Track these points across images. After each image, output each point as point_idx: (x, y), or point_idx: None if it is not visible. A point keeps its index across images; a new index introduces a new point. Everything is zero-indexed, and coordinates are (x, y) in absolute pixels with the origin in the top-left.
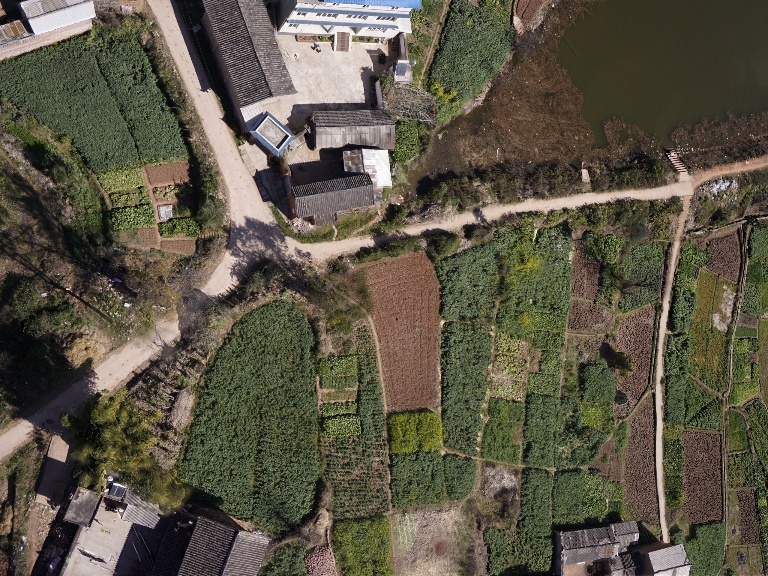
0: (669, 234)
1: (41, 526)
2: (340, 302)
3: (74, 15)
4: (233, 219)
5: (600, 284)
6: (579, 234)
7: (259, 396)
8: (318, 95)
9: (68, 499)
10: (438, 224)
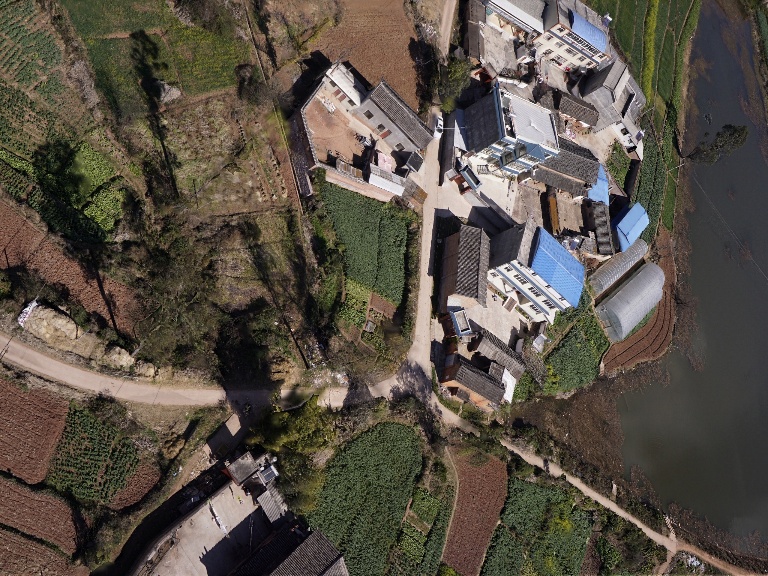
0: (650, 575)
1: (195, 468)
2: (445, 458)
3: (392, 187)
4: (408, 358)
5: None
6: (596, 530)
7: (371, 483)
8: (485, 323)
9: (223, 462)
10: (521, 452)
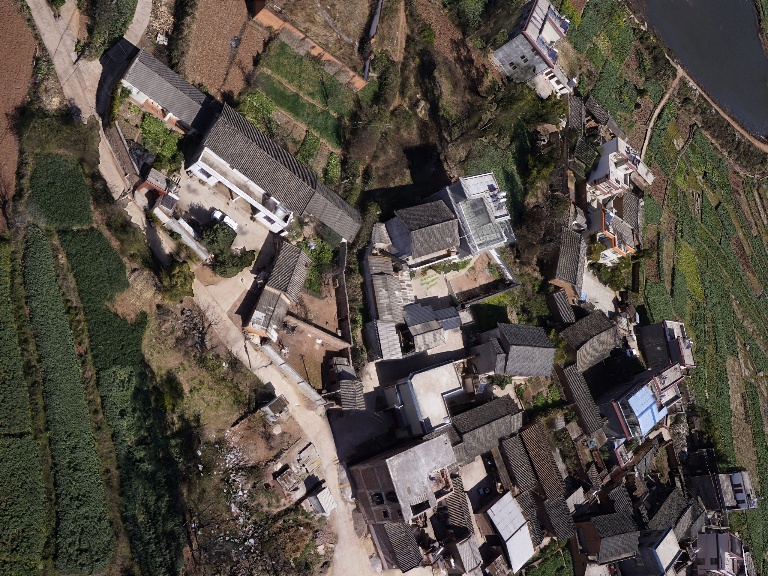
0: (667, 85)
1: None
2: None
3: None
4: None
5: (639, 67)
6: (636, 44)
7: None
8: None
9: None
10: None
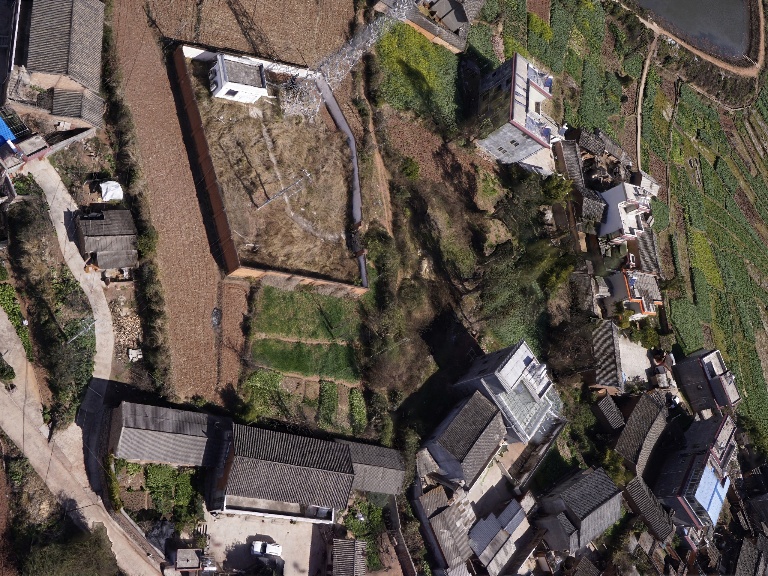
0: (646, 51)
1: None
2: None
3: None
4: None
5: (615, 46)
6: (607, 18)
7: None
8: None
9: None
10: None
